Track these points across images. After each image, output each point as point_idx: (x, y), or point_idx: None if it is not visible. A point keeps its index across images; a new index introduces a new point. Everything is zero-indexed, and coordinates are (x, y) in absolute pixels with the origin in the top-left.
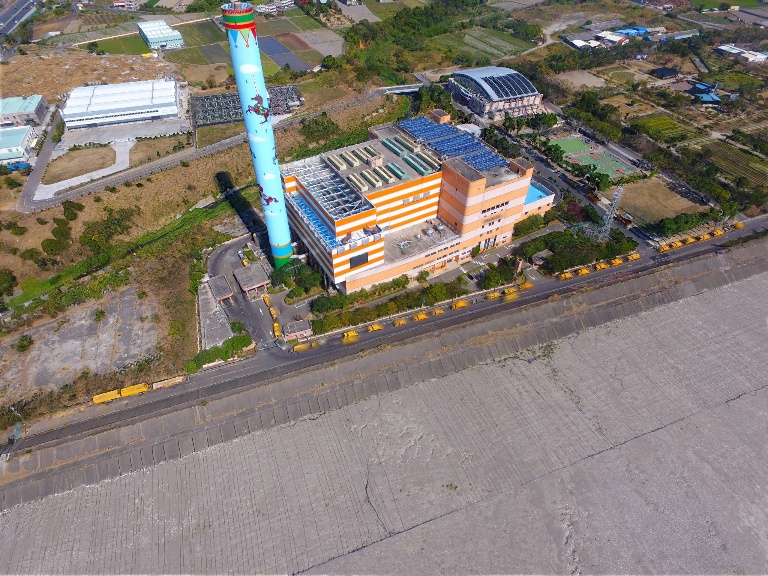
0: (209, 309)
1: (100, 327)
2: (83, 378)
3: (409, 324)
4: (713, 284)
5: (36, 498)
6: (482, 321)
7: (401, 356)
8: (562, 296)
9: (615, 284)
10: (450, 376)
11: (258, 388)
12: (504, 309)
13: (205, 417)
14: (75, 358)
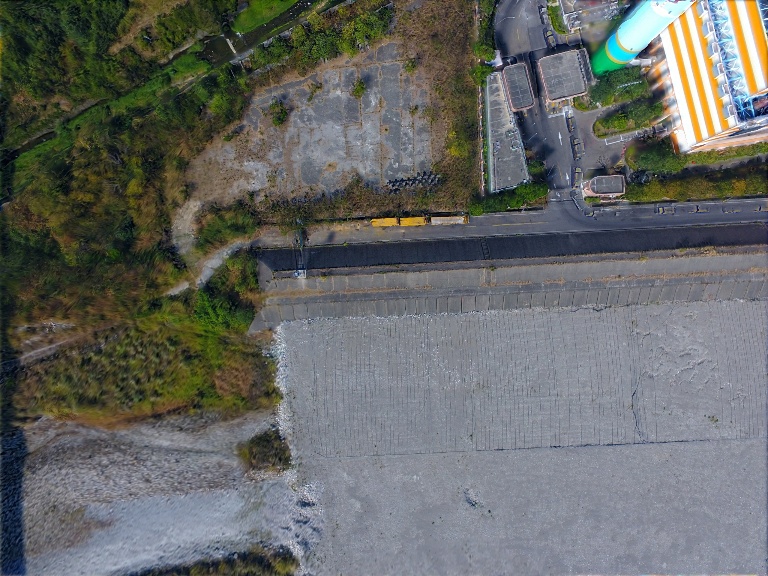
0: (500, 124)
1: (361, 109)
2: (355, 187)
3: (743, 214)
4: None
5: (334, 316)
6: None
7: (721, 266)
8: None
9: None
10: (762, 302)
11: (551, 265)
12: None
13: (490, 281)
14: (340, 153)
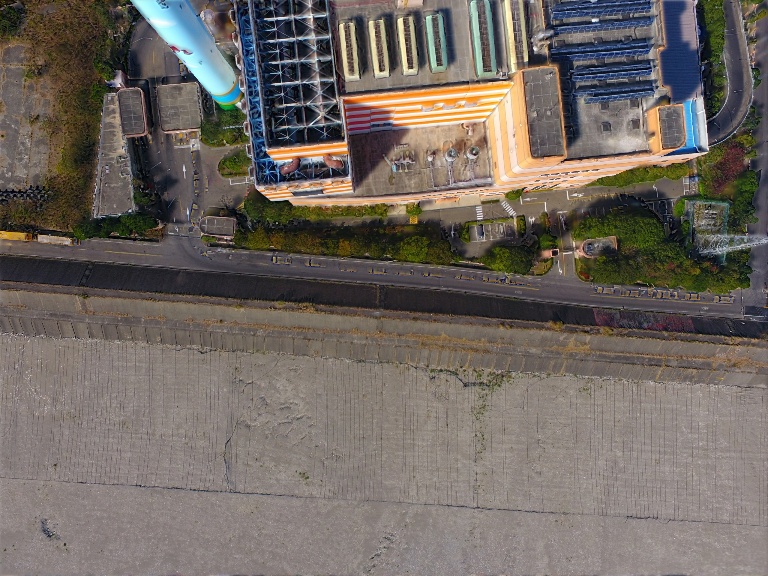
0: (112, 147)
1: None
2: None
3: (359, 273)
4: None
5: None
6: (442, 320)
7: (322, 324)
8: (567, 327)
9: (650, 339)
10: (368, 364)
11: (146, 301)
12: (482, 313)
13: (86, 309)
14: None
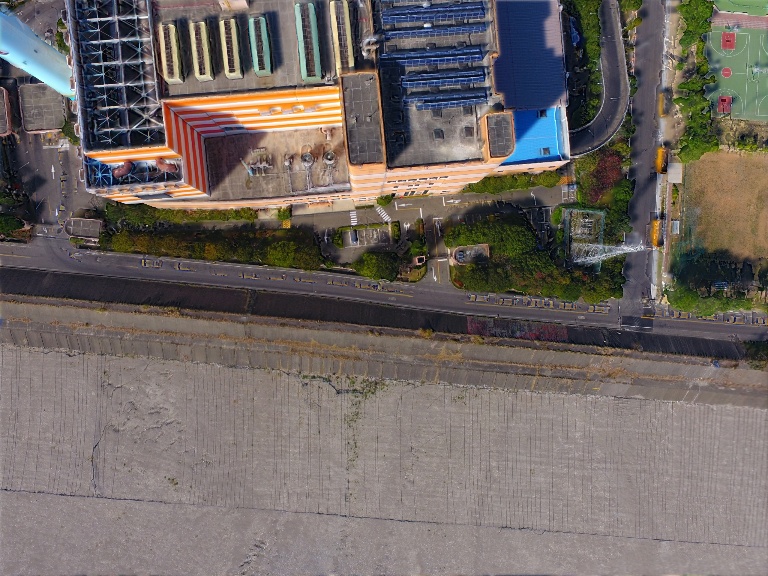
0: None
1: None
2: None
3: (231, 278)
4: (657, 395)
5: None
6: (310, 326)
7: (189, 328)
8: (438, 335)
9: (522, 348)
10: (239, 370)
11: (9, 303)
12: (351, 319)
13: None
14: None
